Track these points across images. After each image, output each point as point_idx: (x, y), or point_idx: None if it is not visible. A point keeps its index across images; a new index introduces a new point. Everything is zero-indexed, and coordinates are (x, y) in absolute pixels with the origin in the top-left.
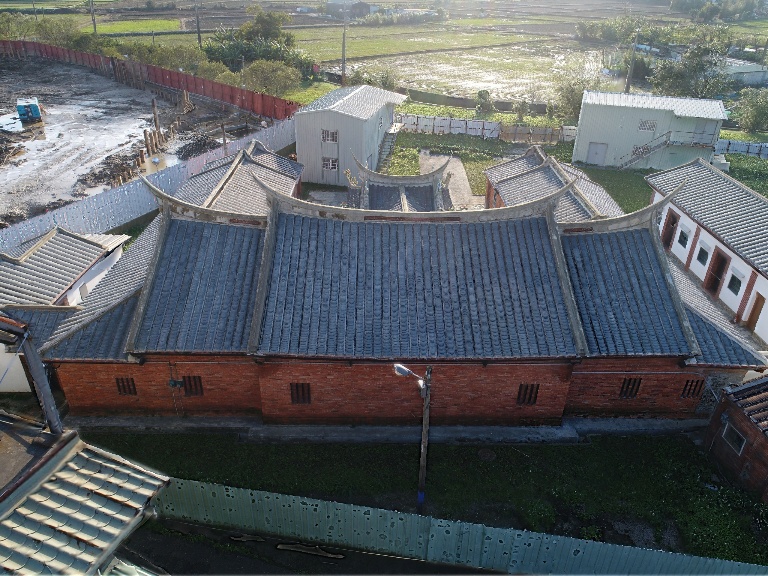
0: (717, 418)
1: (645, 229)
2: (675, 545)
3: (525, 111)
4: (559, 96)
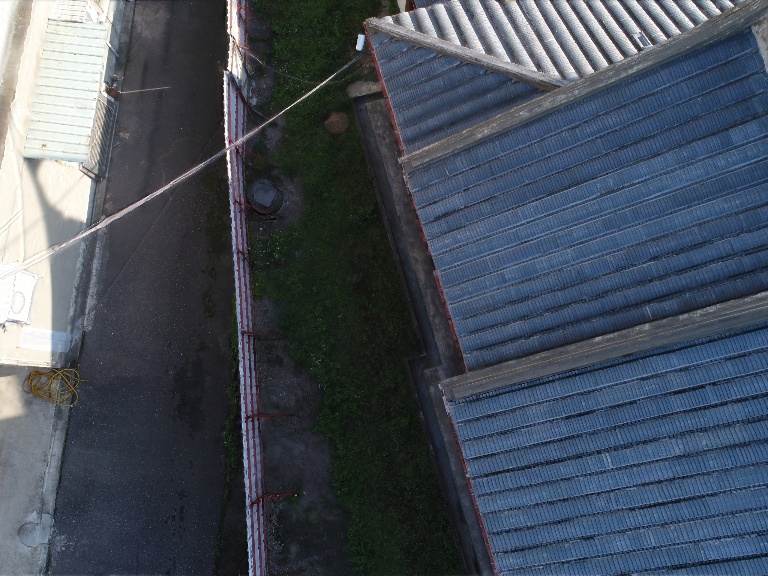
0: None
1: None
2: None
3: None
4: None
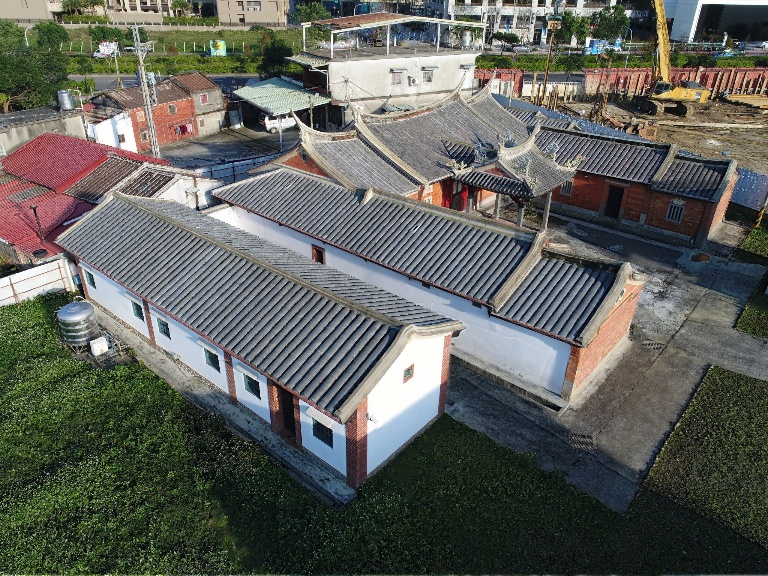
0: None
1: None
2: None
3: None
4: None
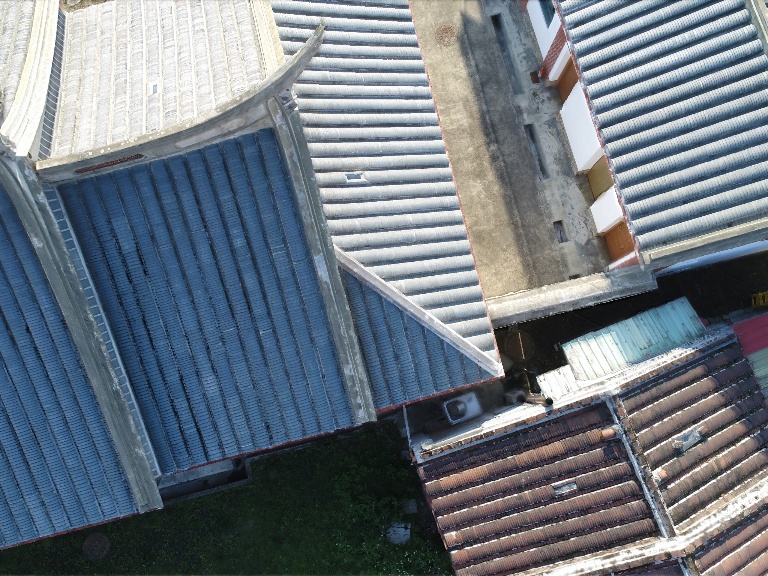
0: None
1: (266, 131)
2: None
3: None
4: None
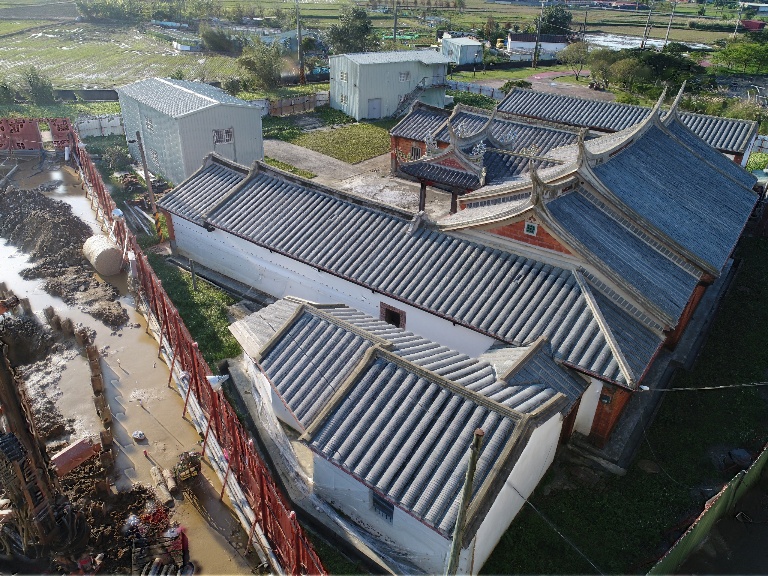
0: (766, 214)
1: (674, 120)
2: None
3: (235, 89)
4: (245, 70)
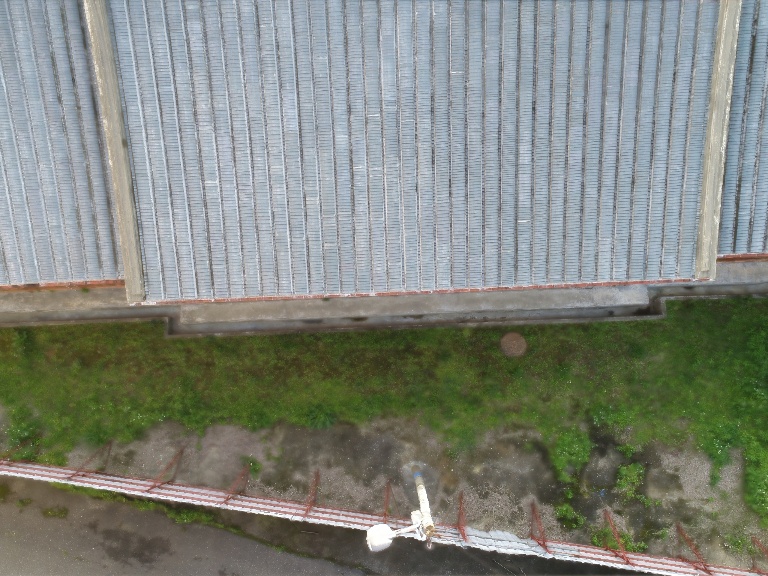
0: None
1: None
2: (732, 490)
3: None
4: None
